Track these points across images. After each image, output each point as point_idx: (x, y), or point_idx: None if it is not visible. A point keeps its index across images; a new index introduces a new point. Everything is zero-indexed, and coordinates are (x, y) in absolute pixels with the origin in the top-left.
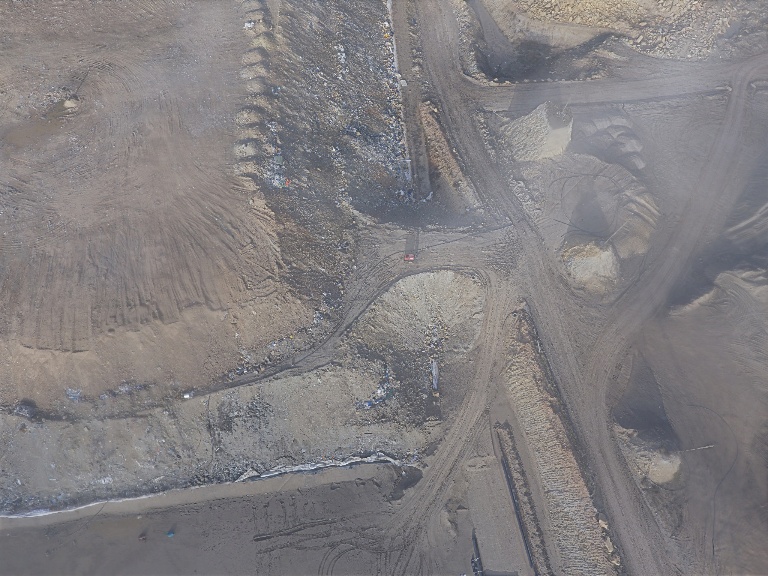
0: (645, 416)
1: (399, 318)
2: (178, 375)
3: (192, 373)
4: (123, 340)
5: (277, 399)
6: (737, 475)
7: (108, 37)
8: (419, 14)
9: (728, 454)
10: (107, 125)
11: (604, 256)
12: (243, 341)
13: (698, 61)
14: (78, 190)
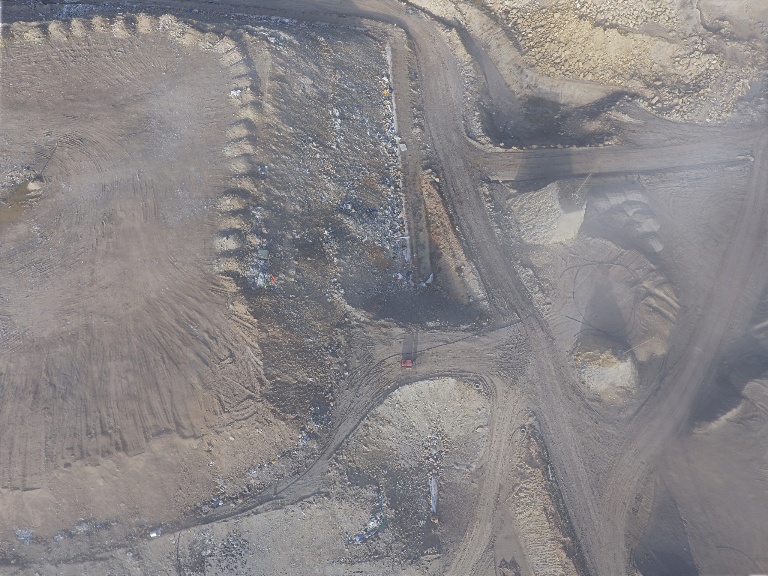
0: (669, 561)
1: (395, 431)
2: (144, 511)
3: (160, 508)
4: (81, 475)
5: (256, 535)
6: None
7: (80, 106)
8: (420, 67)
9: None
10: (74, 212)
11: (622, 367)
12: (219, 469)
13: (717, 126)
14: (37, 291)
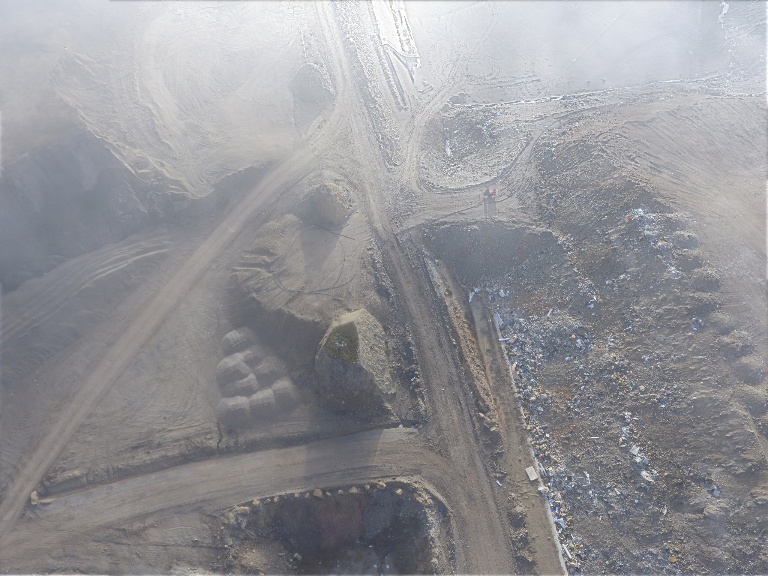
0: (310, 98)
1: None
2: None
3: None
4: None
5: None
6: (258, 72)
7: None
8: None
9: (259, 82)
10: None
11: None
12: None
13: (49, 572)
14: None
